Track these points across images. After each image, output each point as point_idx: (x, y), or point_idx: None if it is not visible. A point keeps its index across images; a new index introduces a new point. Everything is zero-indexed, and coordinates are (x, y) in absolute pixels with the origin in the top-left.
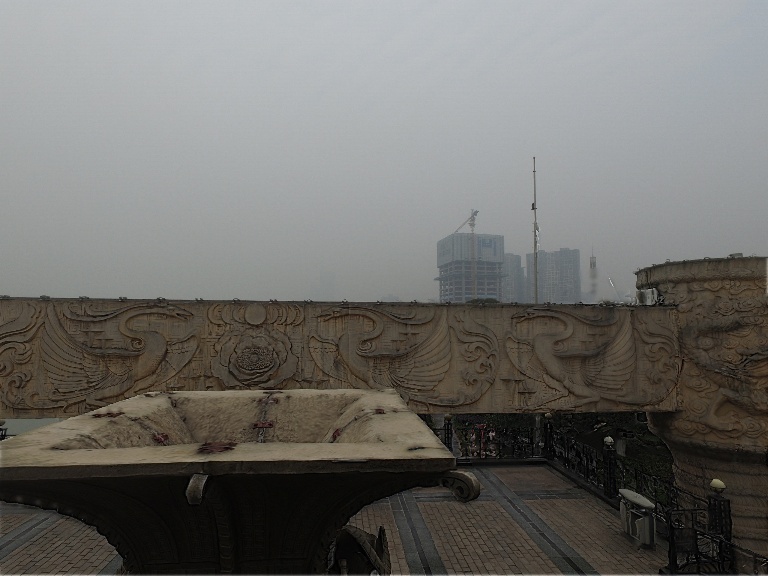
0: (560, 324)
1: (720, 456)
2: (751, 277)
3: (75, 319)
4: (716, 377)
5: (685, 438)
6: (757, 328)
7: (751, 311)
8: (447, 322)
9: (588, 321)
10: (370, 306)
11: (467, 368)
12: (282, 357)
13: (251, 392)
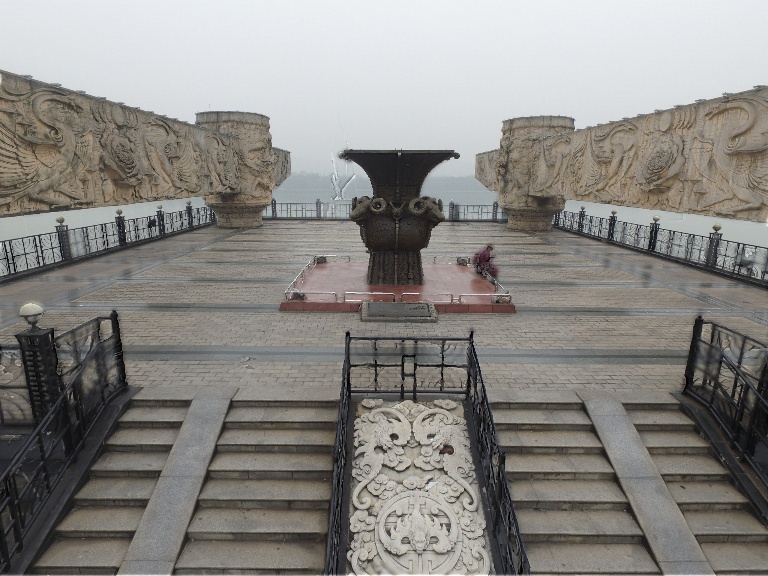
0: None
1: None
2: None
3: (595, 139)
4: None
5: None
6: None
7: None
8: None
9: None
10: (749, 95)
11: None
12: (673, 159)
13: None
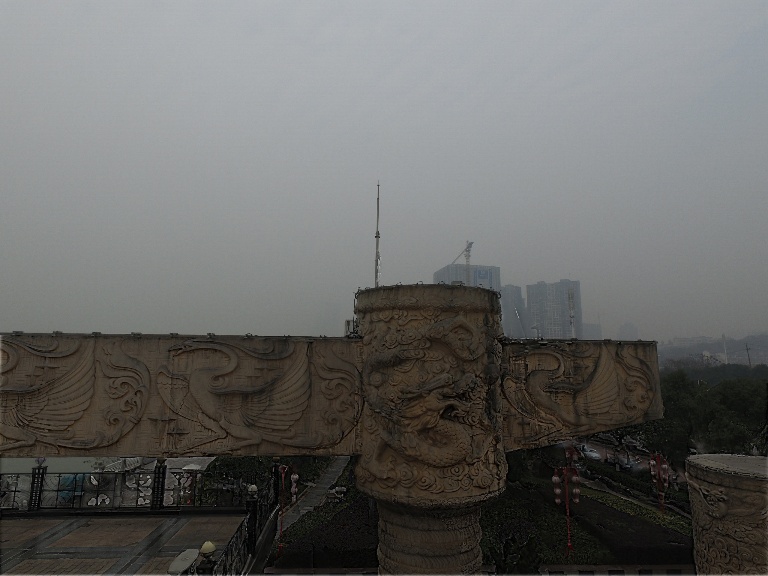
0: (225, 357)
1: (391, 508)
2: (416, 306)
3: None
4: (378, 417)
5: (361, 486)
6: (419, 363)
7: (412, 344)
8: (93, 355)
9: (257, 354)
10: (7, 337)
11: (111, 406)
12: None
13: None
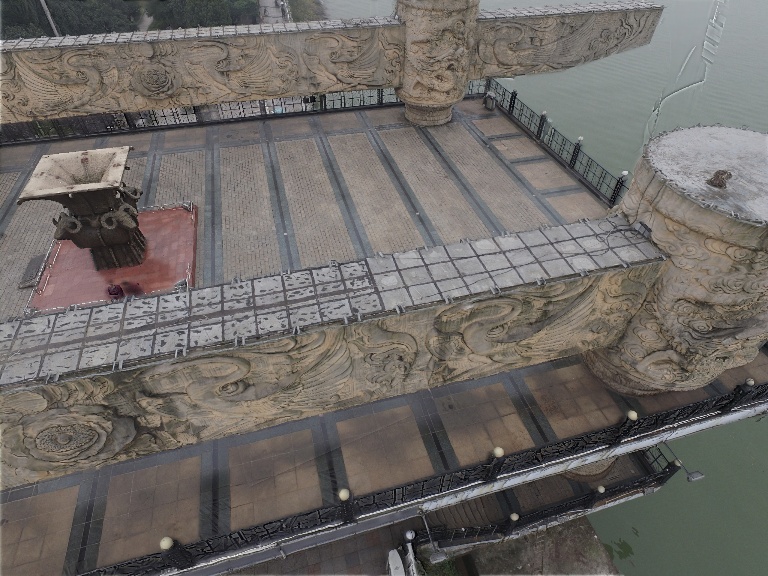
0: None
1: None
2: None
3: None
4: None
5: None
6: None
7: None
8: None
9: None
10: None
11: None
12: None
13: (79, 187)
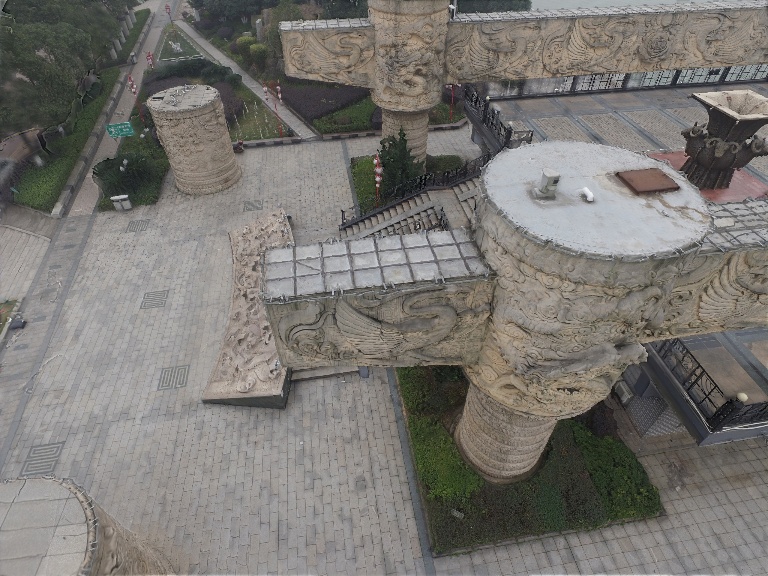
0: None
1: None
2: None
3: None
4: None
5: None
6: None
7: None
8: None
9: None
10: None
11: None
12: None
13: None
